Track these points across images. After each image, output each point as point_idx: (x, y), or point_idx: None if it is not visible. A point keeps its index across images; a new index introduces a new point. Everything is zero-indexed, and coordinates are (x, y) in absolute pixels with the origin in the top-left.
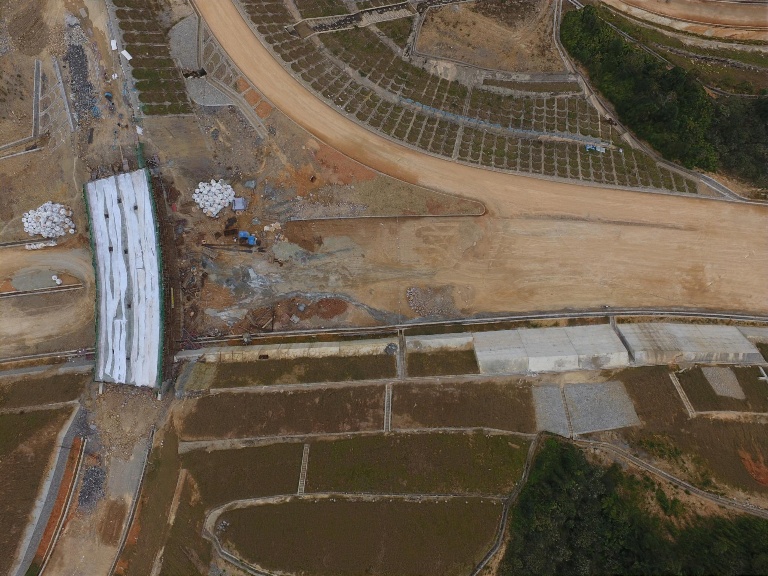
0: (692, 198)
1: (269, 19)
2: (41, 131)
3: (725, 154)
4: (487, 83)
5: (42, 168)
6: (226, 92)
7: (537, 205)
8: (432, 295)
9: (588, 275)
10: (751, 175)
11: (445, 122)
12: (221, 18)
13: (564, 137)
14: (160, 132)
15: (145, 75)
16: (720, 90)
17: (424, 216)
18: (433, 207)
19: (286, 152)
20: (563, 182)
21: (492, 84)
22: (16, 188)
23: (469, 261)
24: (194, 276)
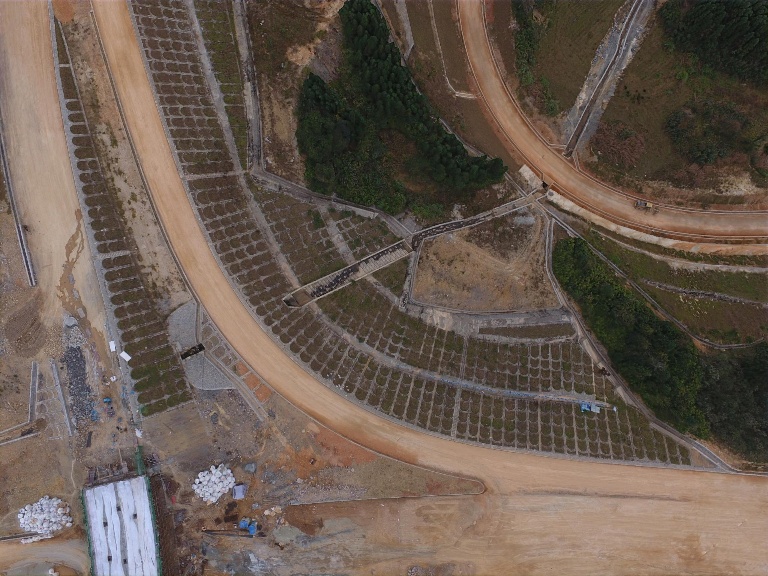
0: (686, 470)
1: (267, 296)
2: (37, 416)
3: (716, 425)
4: (483, 332)
5: (38, 455)
6: (225, 371)
7: (535, 481)
8: (433, 575)
9: (586, 548)
10: (742, 451)
11: (443, 386)
12: (220, 302)
13: (559, 399)
14: (159, 431)
15: (144, 373)
16: (709, 341)
17: (424, 496)
18: (433, 487)
19: (286, 435)
20: (560, 458)
21: (488, 333)
22: (12, 477)
23: (469, 538)
24: (194, 565)
